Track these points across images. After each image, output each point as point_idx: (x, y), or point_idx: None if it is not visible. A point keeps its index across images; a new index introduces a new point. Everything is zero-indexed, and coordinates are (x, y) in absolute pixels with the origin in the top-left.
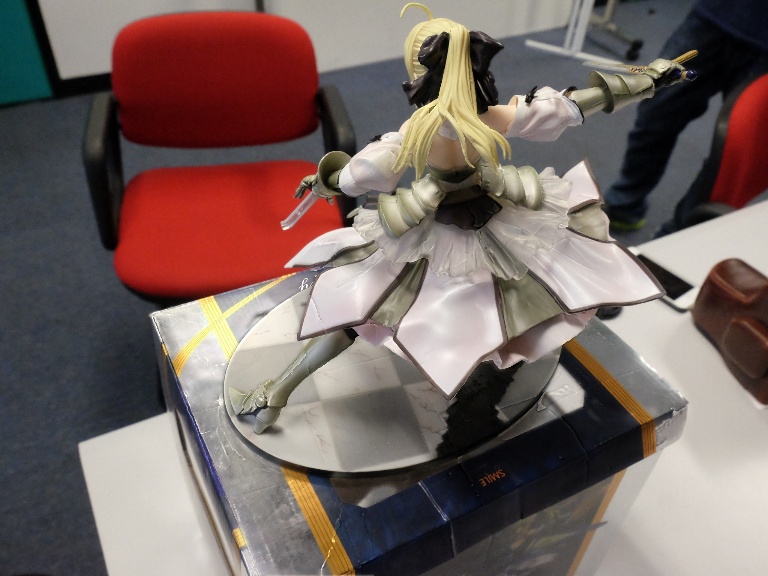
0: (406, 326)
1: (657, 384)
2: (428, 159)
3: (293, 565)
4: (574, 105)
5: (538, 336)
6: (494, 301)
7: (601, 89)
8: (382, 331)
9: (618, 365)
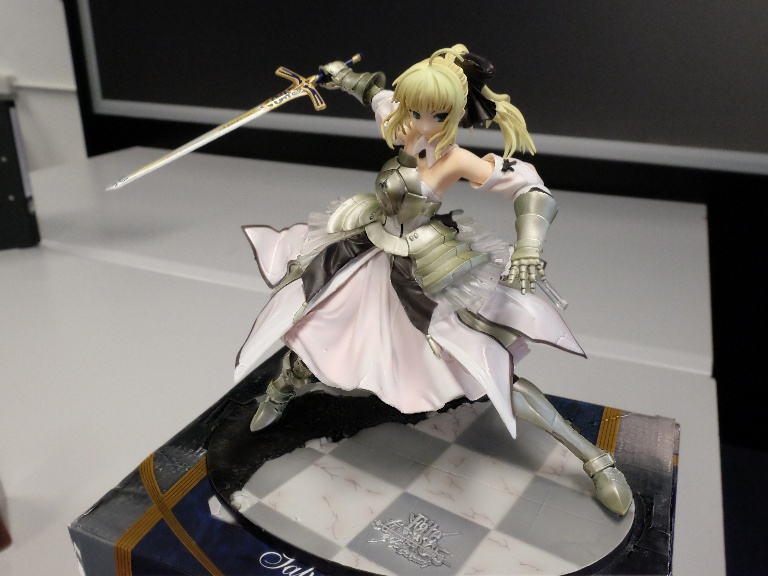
0: None
1: None
2: None
3: (646, 425)
4: None
5: None
6: None
7: None
8: None
9: None
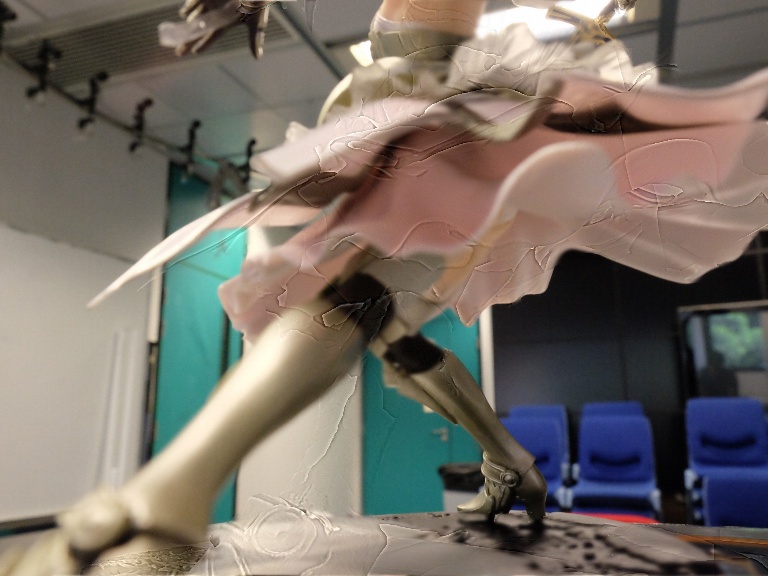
0: None
1: (762, 529)
2: (450, 6)
3: None
4: None
5: None
6: None
7: None
8: (578, 178)
9: None
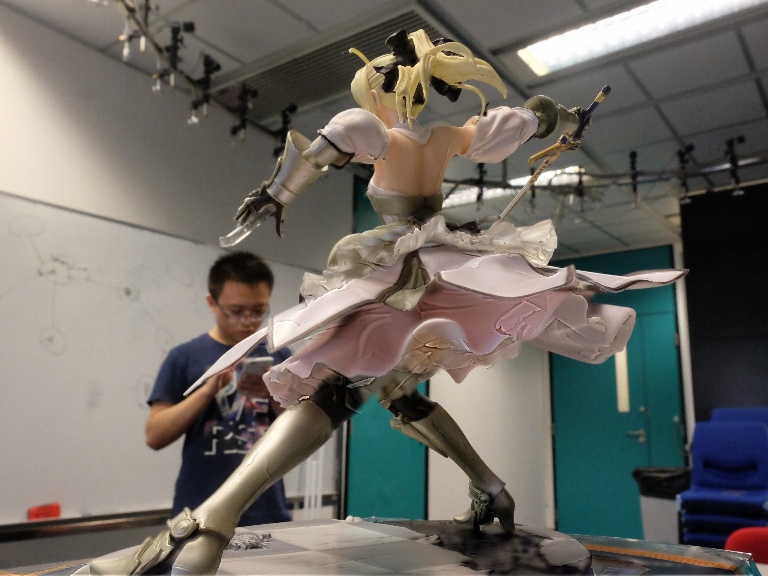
0: (449, 272)
1: None
2: (391, 187)
3: None
4: (526, 110)
5: (598, 312)
6: (532, 271)
7: (539, 112)
8: (398, 336)
9: (644, 547)
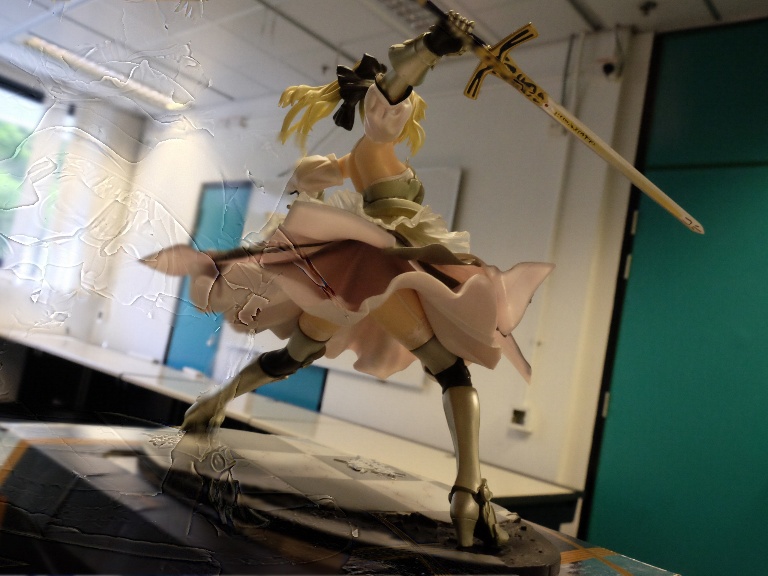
0: None
1: None
2: None
3: None
4: None
5: None
6: None
7: None
8: None
9: None
